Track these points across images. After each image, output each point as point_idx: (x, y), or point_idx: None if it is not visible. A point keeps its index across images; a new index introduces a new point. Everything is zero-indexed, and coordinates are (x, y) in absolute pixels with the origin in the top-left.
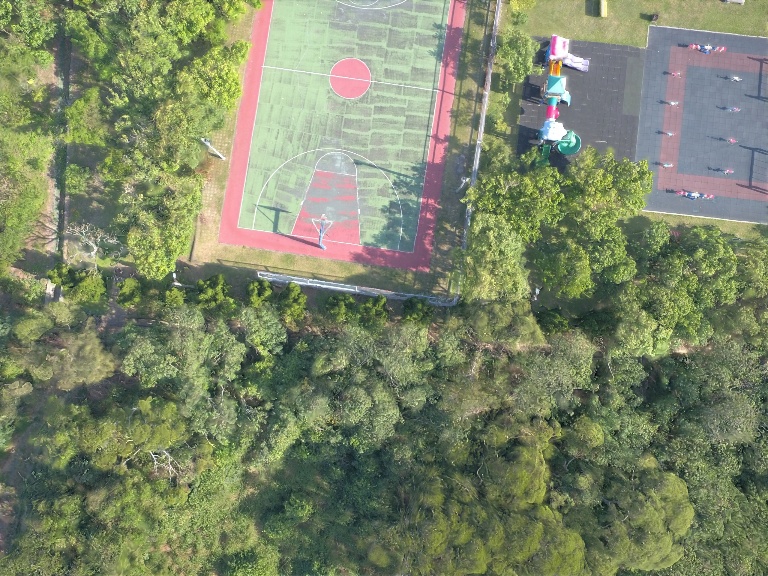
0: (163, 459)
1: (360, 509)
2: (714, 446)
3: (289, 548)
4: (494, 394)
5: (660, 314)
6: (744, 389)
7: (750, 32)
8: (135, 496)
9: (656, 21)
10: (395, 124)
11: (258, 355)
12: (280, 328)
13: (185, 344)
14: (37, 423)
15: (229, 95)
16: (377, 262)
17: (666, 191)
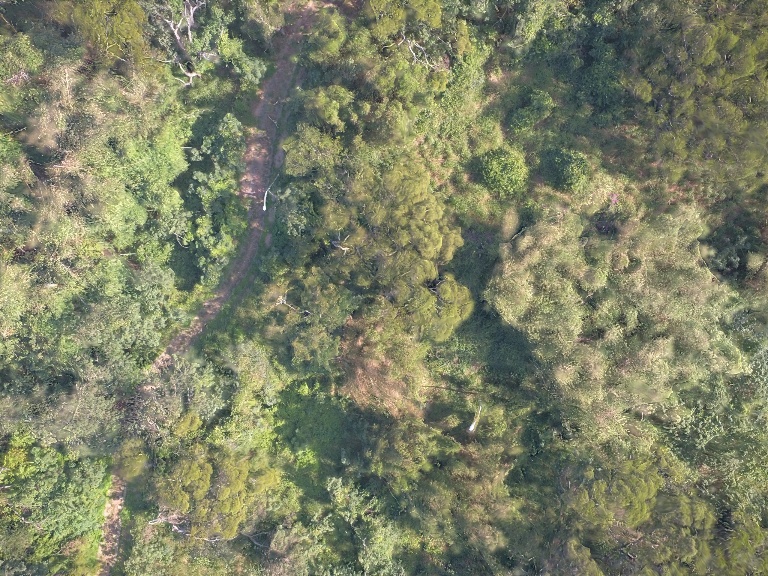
0: (420, 56)
1: (598, 96)
2: None
3: (533, 144)
4: None
5: None
6: None
7: None
8: (410, 68)
9: None
10: None
11: None
12: None
13: None
14: (282, 69)
15: None
16: None
17: None
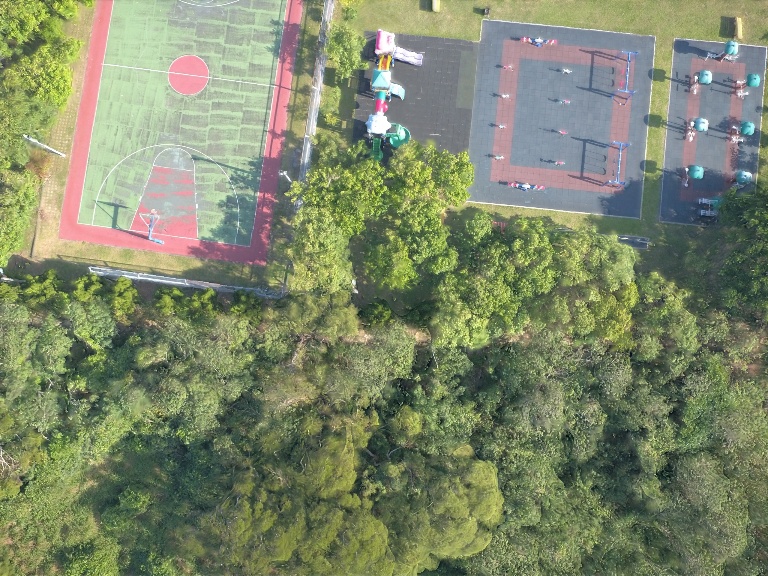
0: None
1: (195, 500)
2: (532, 433)
3: (128, 539)
4: (314, 384)
5: (475, 303)
6: (559, 377)
7: (582, 25)
8: None
9: (489, 15)
10: (232, 120)
11: (89, 349)
12: (110, 322)
13: (7, 338)
14: None
15: (59, 92)
16: (214, 256)
17: (499, 183)
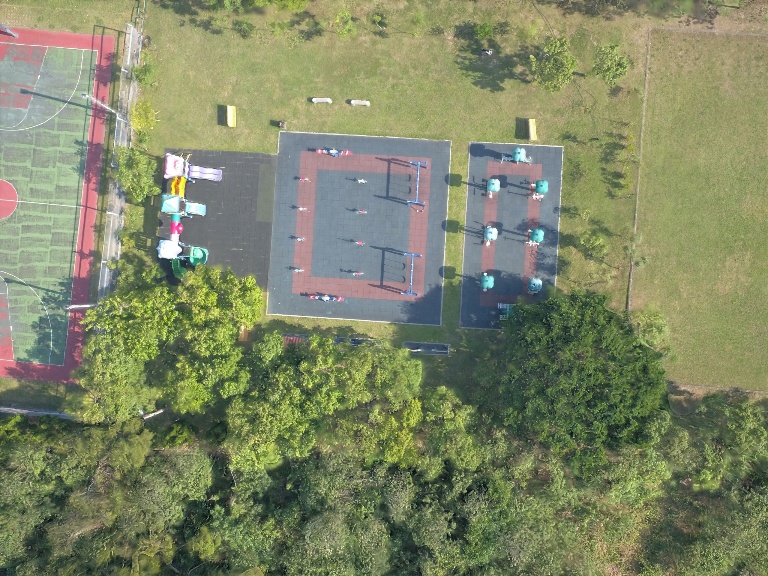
0: None
1: None
2: (322, 551)
3: None
4: (111, 510)
5: (259, 428)
6: (343, 497)
7: (377, 133)
8: None
9: (286, 127)
10: (42, 242)
11: None
12: None
13: None
14: None
15: None
16: (30, 376)
17: (300, 294)
